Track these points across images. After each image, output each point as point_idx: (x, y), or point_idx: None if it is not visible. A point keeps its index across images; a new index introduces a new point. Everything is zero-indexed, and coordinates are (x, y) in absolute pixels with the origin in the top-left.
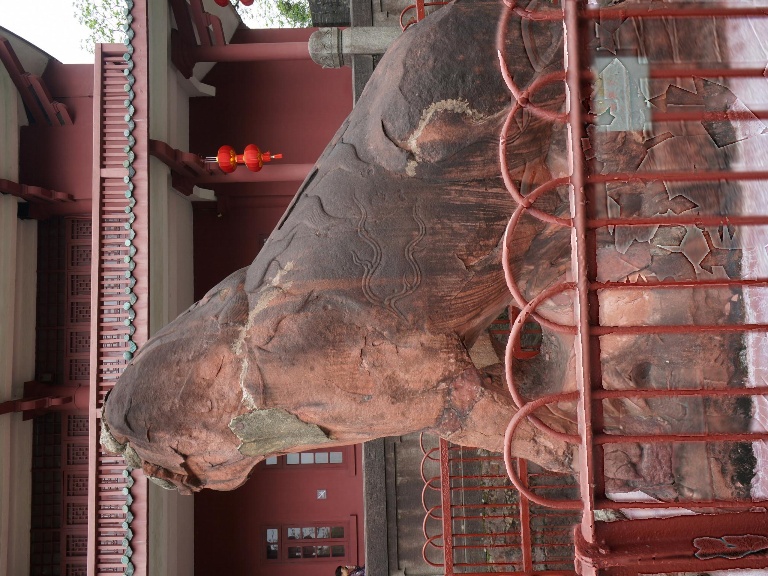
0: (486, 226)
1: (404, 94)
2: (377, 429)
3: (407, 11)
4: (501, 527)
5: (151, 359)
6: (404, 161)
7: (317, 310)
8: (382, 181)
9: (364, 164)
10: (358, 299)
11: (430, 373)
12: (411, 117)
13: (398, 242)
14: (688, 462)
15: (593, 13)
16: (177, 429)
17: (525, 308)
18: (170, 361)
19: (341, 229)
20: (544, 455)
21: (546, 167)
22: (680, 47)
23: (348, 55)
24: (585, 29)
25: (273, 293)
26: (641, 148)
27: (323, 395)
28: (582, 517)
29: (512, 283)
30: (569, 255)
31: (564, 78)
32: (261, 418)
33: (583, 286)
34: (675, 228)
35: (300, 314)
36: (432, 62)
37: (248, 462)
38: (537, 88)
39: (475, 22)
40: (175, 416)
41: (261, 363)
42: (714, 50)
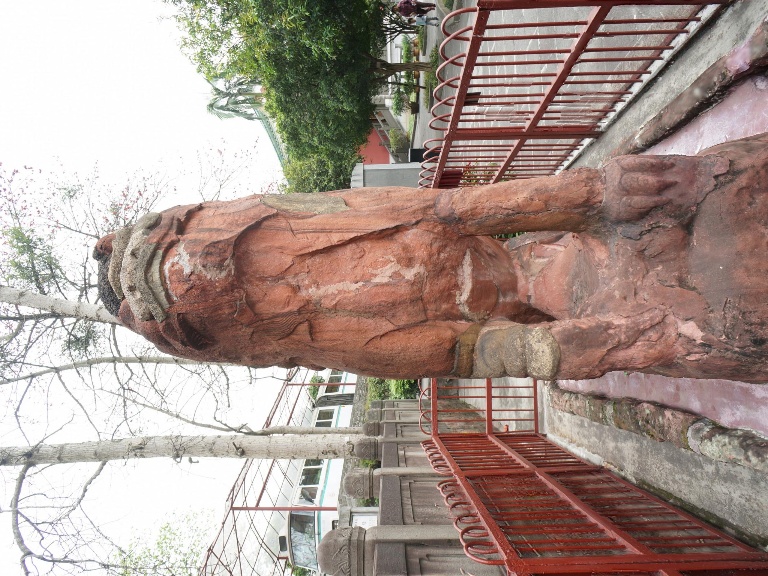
0: None
1: None
2: (394, 197)
3: None
4: None
5: None
6: None
7: None
8: None
9: None
10: None
11: None
12: None
13: None
14: None
15: None
16: None
17: None
18: None
19: None
20: None
21: None
22: None
23: (377, 478)
24: None
25: None
26: None
27: None
28: None
29: None
30: None
31: None
32: None
33: None
34: None
35: None
36: None
37: (256, 215)
38: None
39: None
40: None
41: None
42: None
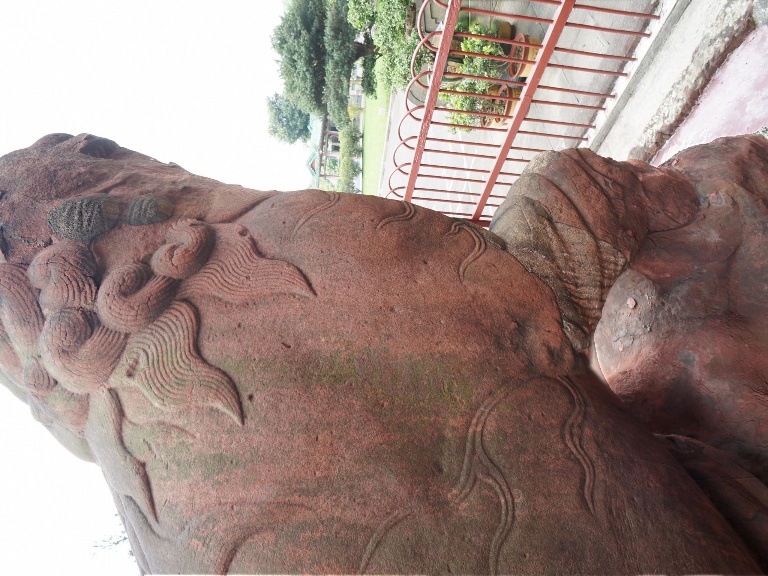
0: None
1: None
2: None
3: None
4: None
5: None
6: None
7: None
8: None
9: None
10: None
11: None
12: None
13: None
14: None
15: None
16: None
17: None
18: None
19: None
20: None
21: None
22: None
23: None
24: None
25: None
26: None
27: None
28: None
29: None
30: None
31: None
32: None
33: None
34: None
35: None
36: None
37: None
38: None
39: None
40: None
41: None
42: None
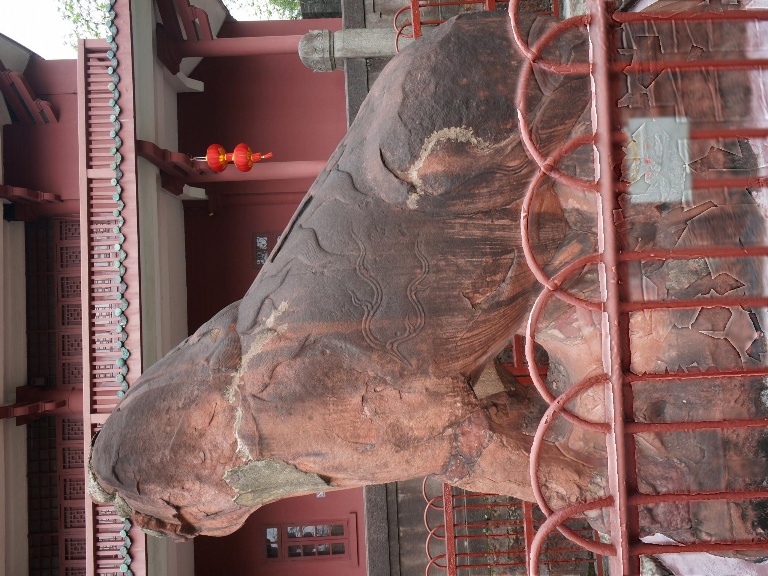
0: (493, 261)
1: (404, 121)
2: (380, 476)
3: (401, 13)
4: (505, 543)
5: (139, 406)
6: (405, 194)
7: (315, 355)
8: (381, 214)
9: (362, 195)
10: (358, 343)
11: (436, 419)
12: (412, 146)
13: (400, 281)
14: (706, 507)
15: (625, 65)
16: (168, 481)
17: (552, 406)
18: (159, 409)
19: (338, 267)
20: (556, 501)
21: (554, 193)
22: (723, 103)
23: (340, 59)
24: (615, 83)
25: (267, 336)
26: (656, 176)
27: (323, 445)
28: (586, 531)
29: (537, 376)
30: (579, 286)
31: (592, 140)
32: (257, 469)
33: (615, 375)
34: (692, 261)
35: (297, 360)
36: (433, 87)
37: (245, 510)
38: (546, 113)
39: (479, 42)
40: (166, 468)
41: (256, 412)
42: (761, 105)
